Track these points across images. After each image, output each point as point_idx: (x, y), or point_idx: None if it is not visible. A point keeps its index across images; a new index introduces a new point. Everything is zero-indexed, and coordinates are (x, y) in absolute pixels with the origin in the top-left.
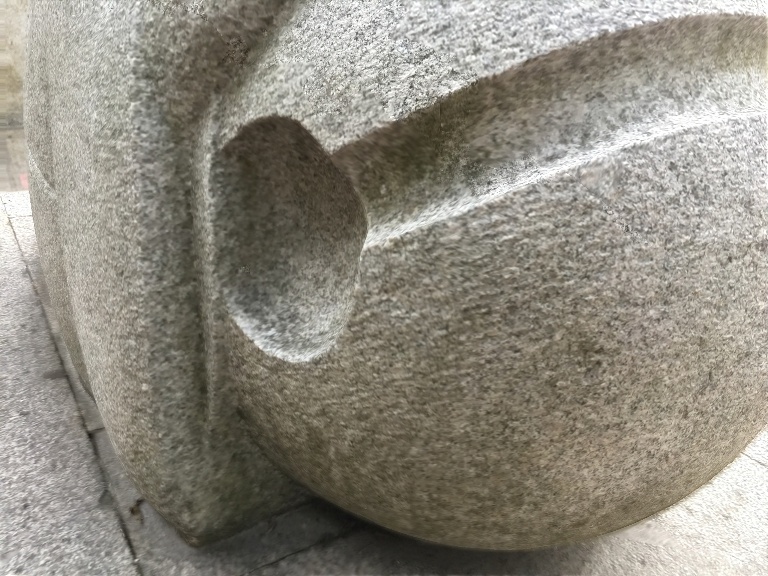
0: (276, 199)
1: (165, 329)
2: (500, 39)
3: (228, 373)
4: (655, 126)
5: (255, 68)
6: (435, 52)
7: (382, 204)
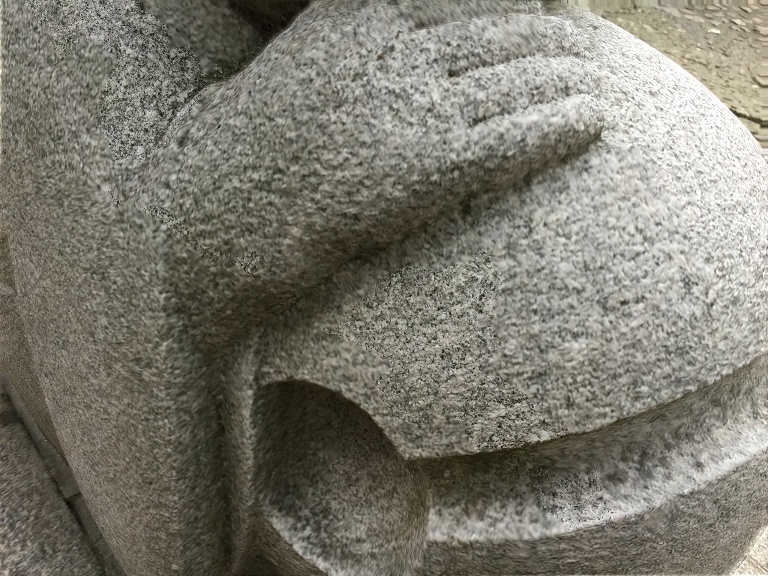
0: (309, 401)
1: (196, 524)
2: (594, 398)
3: (254, 543)
4: (706, 450)
5: (310, 323)
6: (528, 399)
7: (445, 485)
